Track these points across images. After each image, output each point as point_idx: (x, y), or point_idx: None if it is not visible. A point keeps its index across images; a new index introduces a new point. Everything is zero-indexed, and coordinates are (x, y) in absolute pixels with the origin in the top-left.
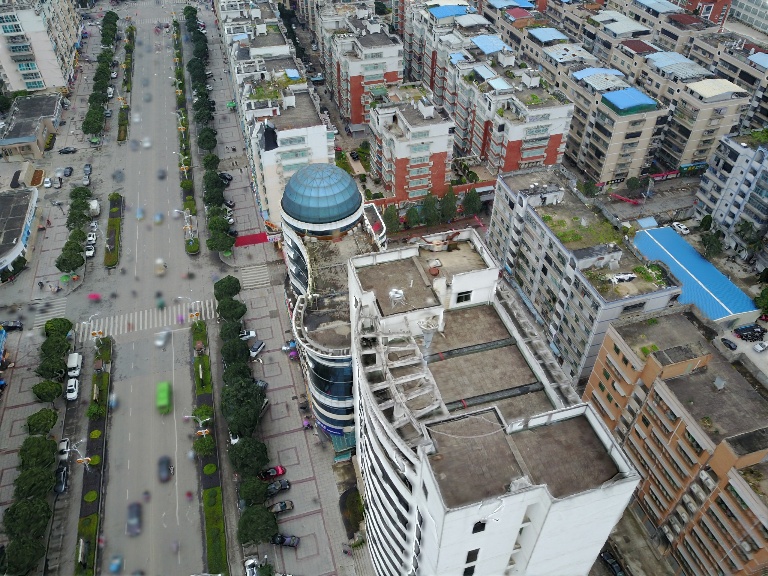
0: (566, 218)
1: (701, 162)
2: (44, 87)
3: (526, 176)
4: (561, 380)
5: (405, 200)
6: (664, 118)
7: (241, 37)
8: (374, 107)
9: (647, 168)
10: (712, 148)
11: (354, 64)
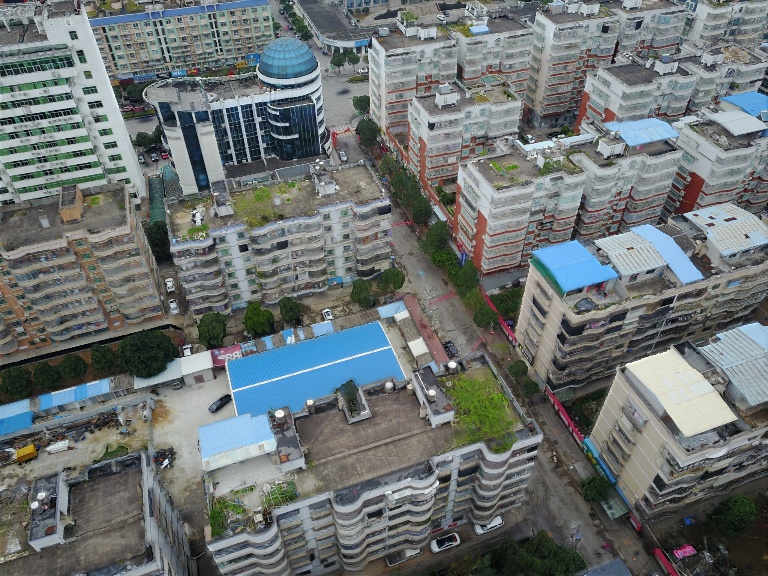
0: (292, 196)
1: (611, 472)
2: None
3: (369, 179)
4: None
5: None
6: (567, 323)
7: (555, 3)
8: None
9: (552, 381)
10: (627, 471)
11: (589, 79)
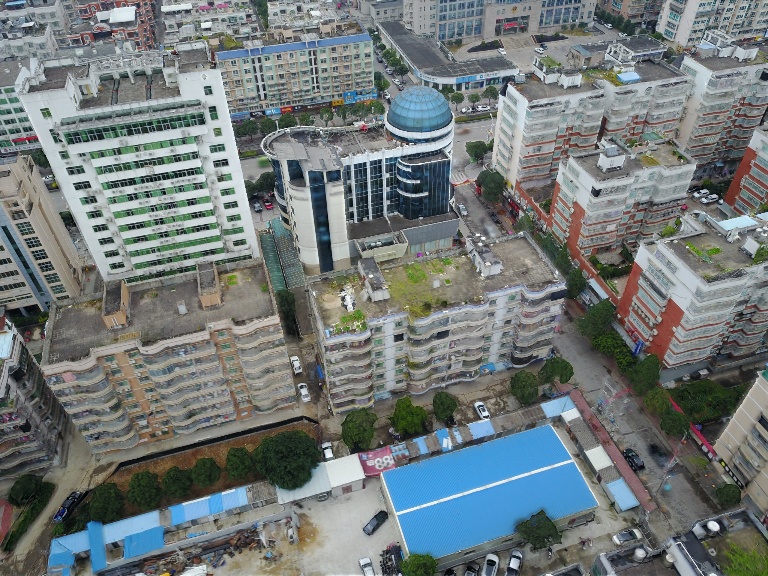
0: (450, 276)
1: None
2: (672, 39)
3: (534, 256)
4: (116, 119)
5: (551, 229)
6: None
7: (704, 46)
8: (631, 145)
9: None
10: None
11: (757, 134)
